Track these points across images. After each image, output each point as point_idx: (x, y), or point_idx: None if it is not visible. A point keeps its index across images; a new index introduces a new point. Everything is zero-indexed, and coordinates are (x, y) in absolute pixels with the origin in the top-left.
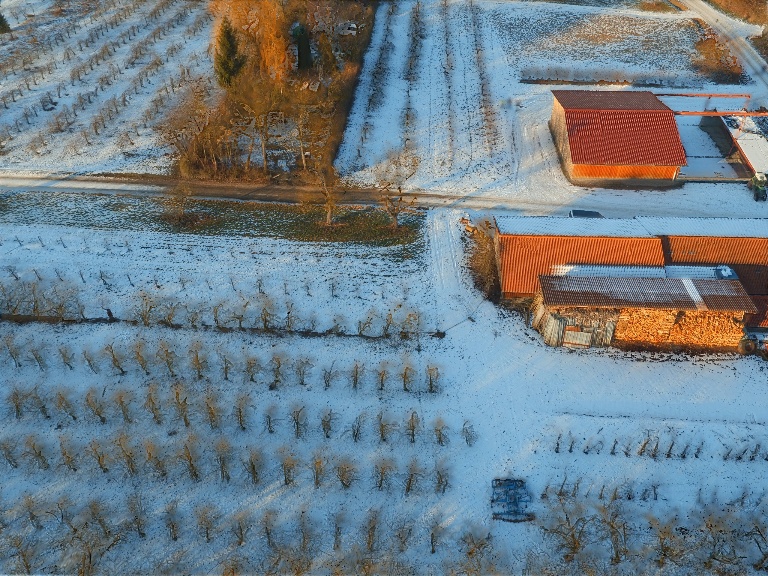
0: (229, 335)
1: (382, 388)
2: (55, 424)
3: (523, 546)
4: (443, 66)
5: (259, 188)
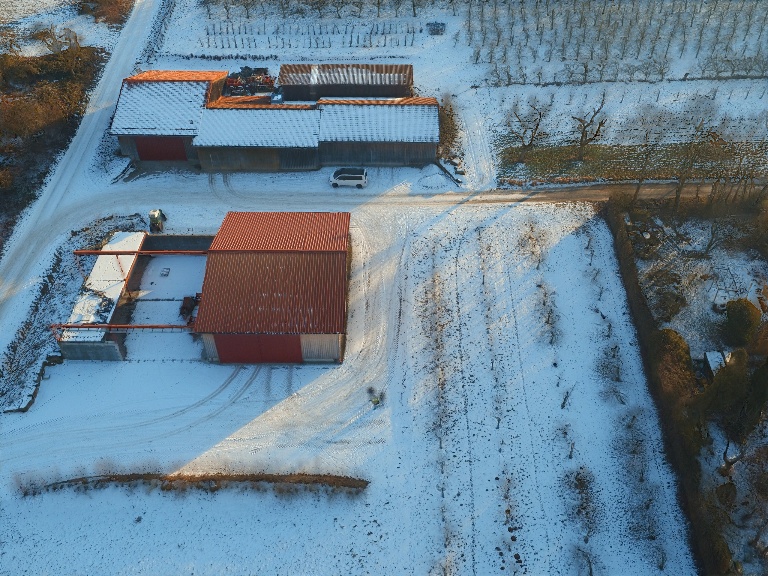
0: (605, 78)
1: (504, 63)
2: (663, 39)
3: (432, 18)
4: (522, 568)
5: (669, 195)
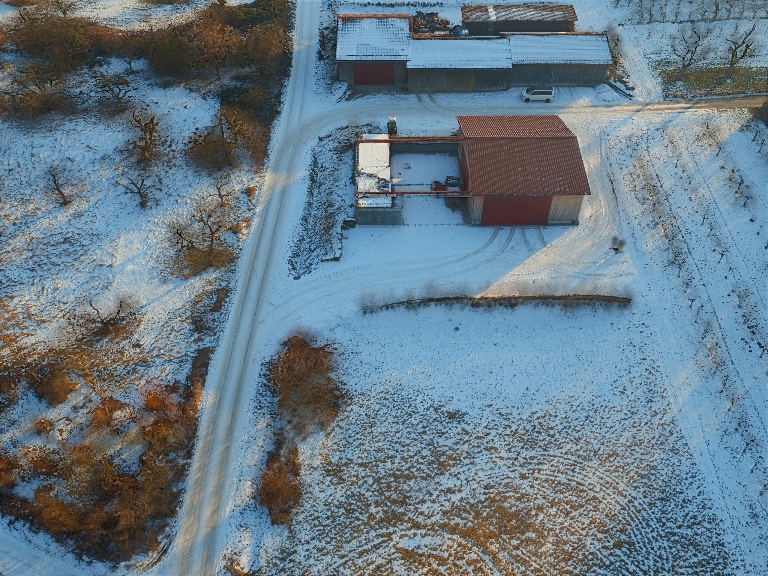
0: (731, 17)
1: None
2: None
3: None
4: (765, 350)
5: None
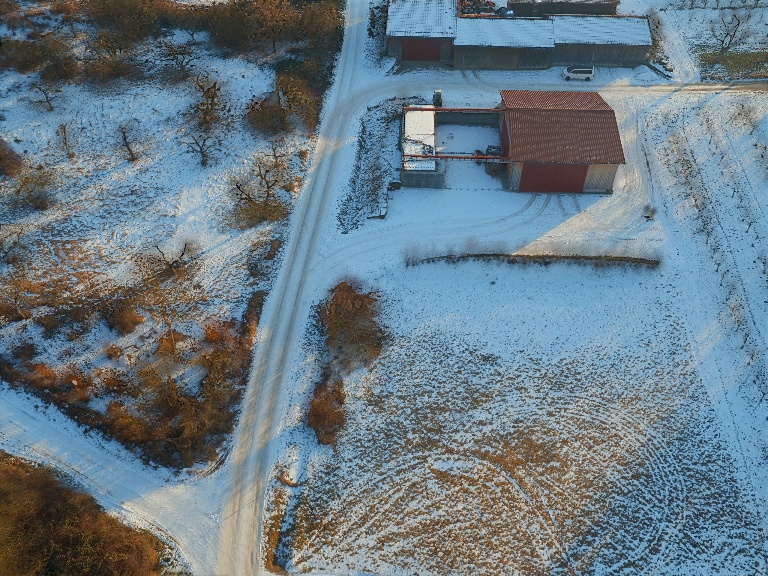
0: None
1: None
2: None
3: None
4: None
5: None
